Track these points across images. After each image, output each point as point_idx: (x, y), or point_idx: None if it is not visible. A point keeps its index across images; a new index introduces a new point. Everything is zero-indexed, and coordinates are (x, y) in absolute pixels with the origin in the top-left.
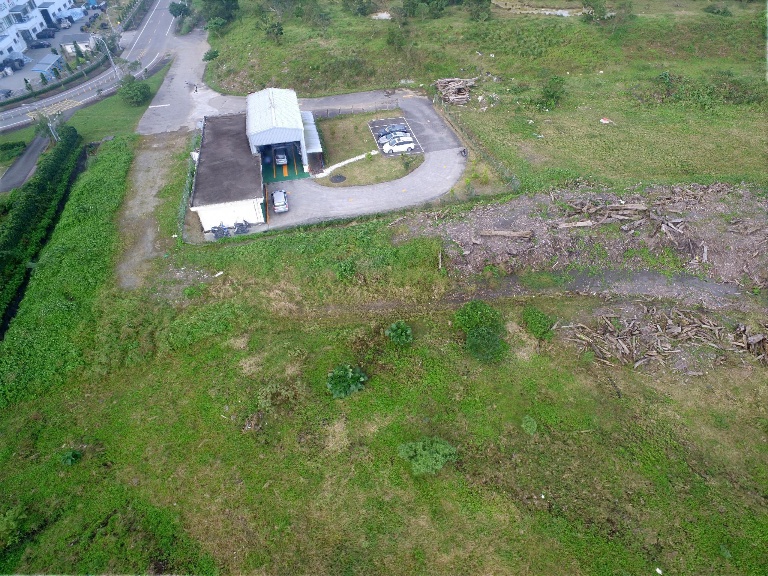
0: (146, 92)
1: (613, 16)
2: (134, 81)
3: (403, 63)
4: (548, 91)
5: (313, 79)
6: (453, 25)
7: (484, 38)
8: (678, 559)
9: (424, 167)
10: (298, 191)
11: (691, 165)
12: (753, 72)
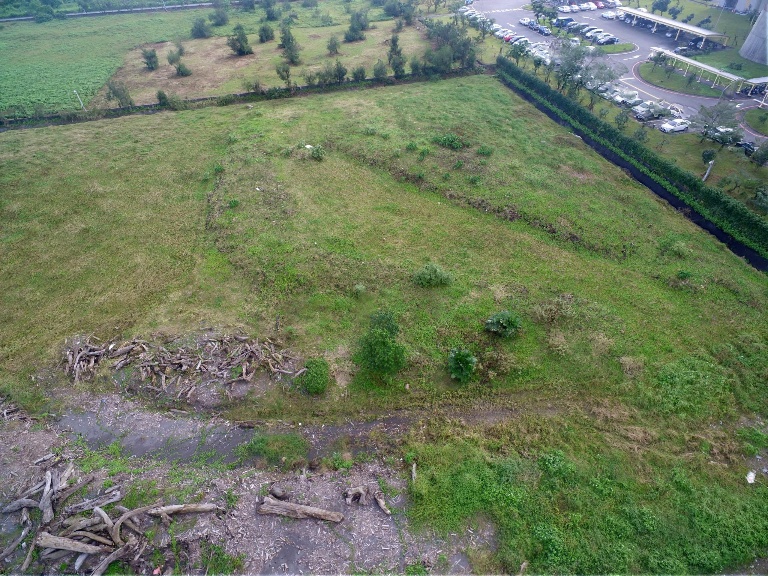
0: None
1: None
2: None
3: None
4: None
5: None
6: None
7: None
8: None
9: None
10: None
11: None
12: None
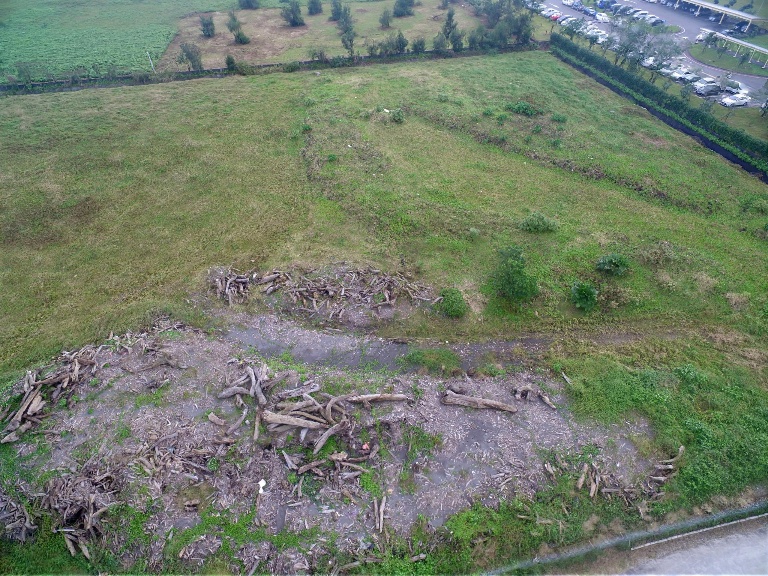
0: None
1: None
2: None
3: None
4: None
5: None
6: None
7: None
8: None
9: None
10: None
11: None
12: None
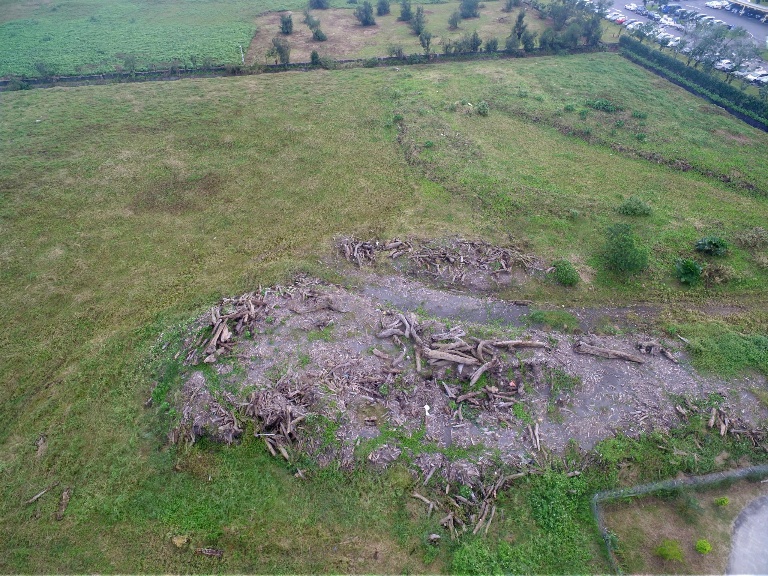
0: None
1: None
2: None
3: None
4: None
5: None
6: None
7: None
8: None
9: None
10: None
11: None
12: None
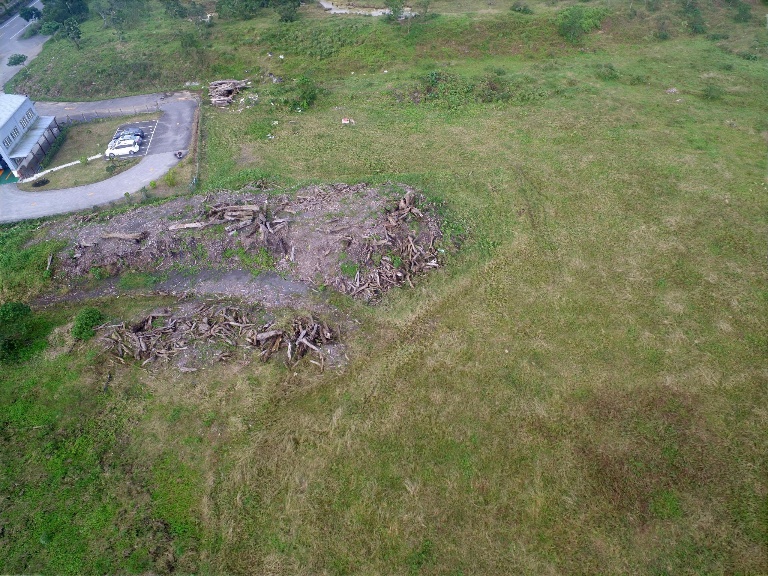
0: None
1: (417, 15)
2: None
3: (191, 65)
4: None
5: (96, 83)
6: (257, 26)
7: (280, 39)
8: (5, 546)
9: (132, 170)
10: None
11: (385, 164)
12: (528, 70)
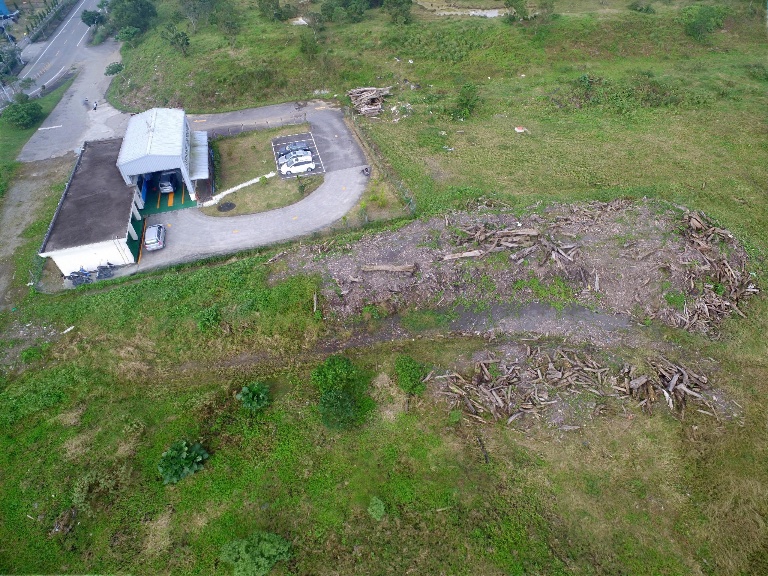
0: (36, 113)
1: (537, 16)
2: (28, 100)
3: (317, 72)
4: (462, 99)
5: (219, 93)
6: (372, 30)
7: (403, 43)
8: None
9: (322, 189)
10: (180, 223)
11: (600, 177)
12: (674, 71)
